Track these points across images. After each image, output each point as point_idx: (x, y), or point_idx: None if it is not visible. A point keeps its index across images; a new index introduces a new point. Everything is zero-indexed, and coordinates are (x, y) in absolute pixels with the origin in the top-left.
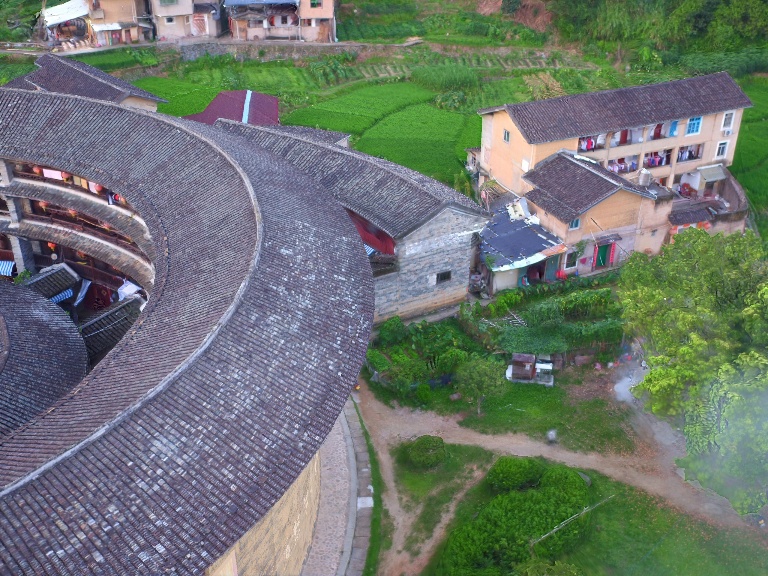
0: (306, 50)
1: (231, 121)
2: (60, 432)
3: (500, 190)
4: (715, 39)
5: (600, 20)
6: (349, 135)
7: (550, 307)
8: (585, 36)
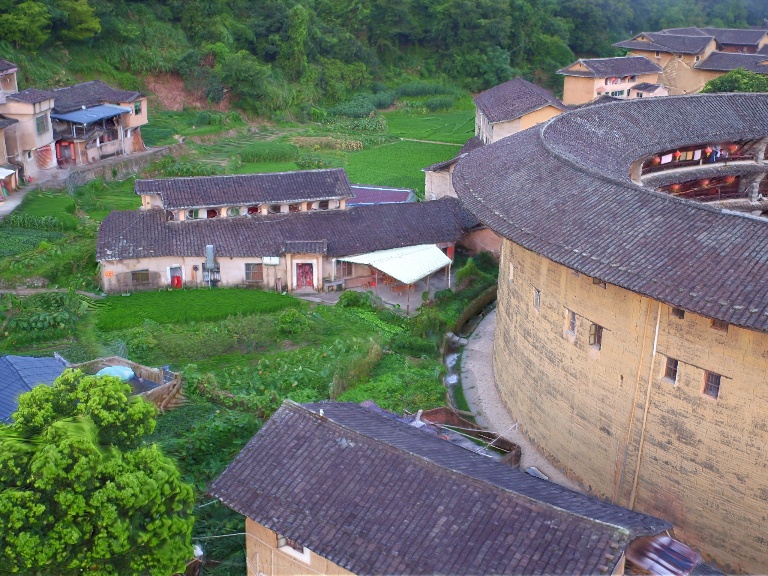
0: (141, 161)
1: None
2: None
3: None
4: (336, 94)
5: (273, 94)
6: None
7: None
8: (266, 110)
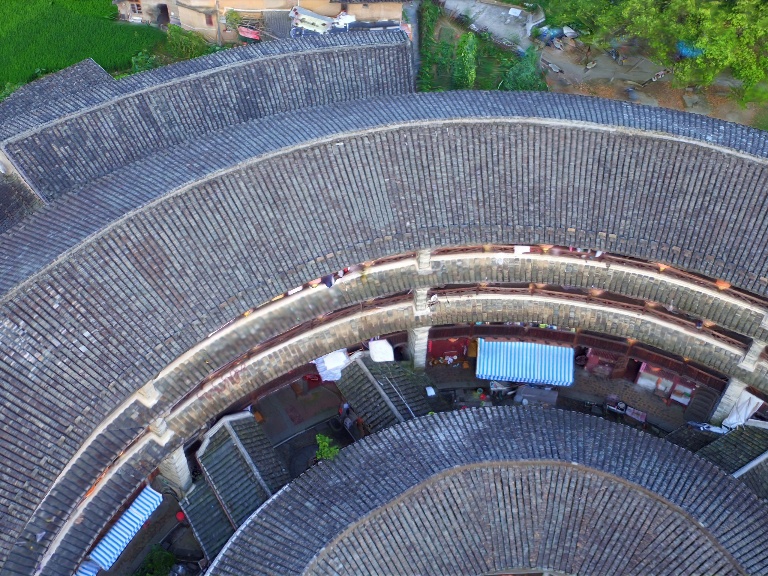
0: None
1: (25, 134)
2: None
3: (254, 16)
4: None
5: None
6: (91, 59)
7: (534, 71)
8: None
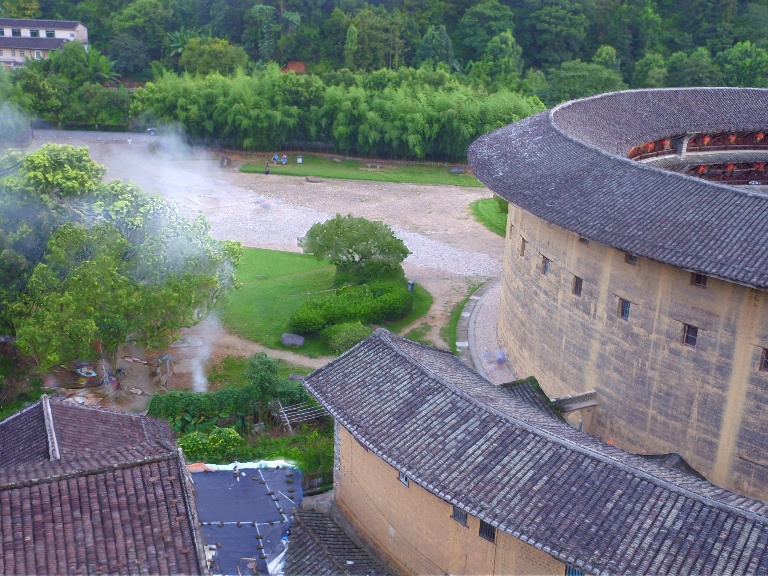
0: None
1: None
2: None
3: None
4: None
5: None
6: None
7: None
8: None
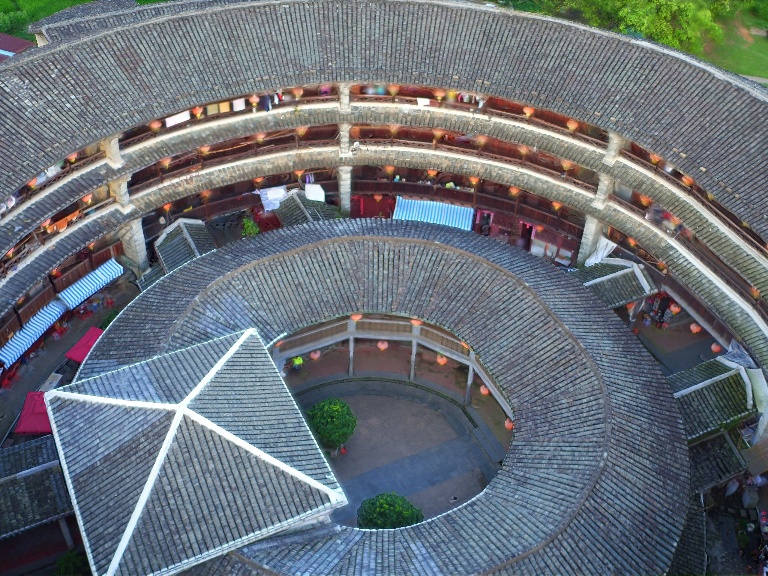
0: None
1: (63, 23)
2: (765, 156)
3: None
4: None
5: None
6: None
7: None
8: None
